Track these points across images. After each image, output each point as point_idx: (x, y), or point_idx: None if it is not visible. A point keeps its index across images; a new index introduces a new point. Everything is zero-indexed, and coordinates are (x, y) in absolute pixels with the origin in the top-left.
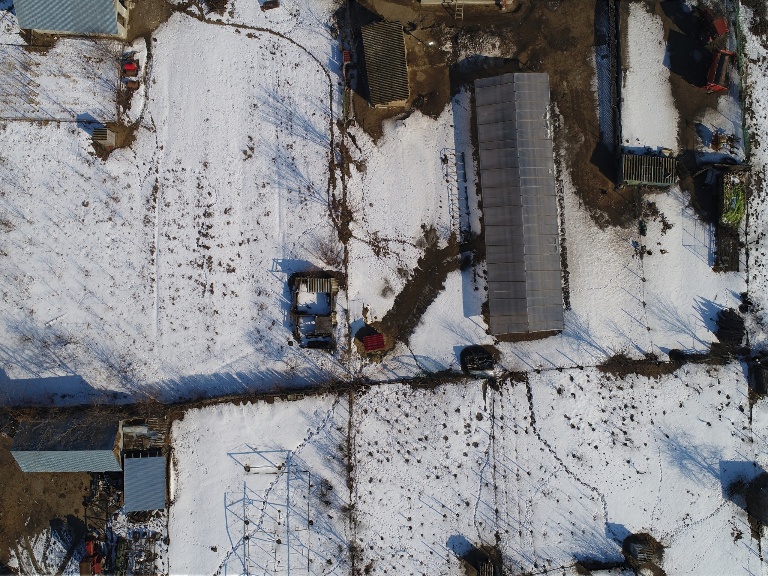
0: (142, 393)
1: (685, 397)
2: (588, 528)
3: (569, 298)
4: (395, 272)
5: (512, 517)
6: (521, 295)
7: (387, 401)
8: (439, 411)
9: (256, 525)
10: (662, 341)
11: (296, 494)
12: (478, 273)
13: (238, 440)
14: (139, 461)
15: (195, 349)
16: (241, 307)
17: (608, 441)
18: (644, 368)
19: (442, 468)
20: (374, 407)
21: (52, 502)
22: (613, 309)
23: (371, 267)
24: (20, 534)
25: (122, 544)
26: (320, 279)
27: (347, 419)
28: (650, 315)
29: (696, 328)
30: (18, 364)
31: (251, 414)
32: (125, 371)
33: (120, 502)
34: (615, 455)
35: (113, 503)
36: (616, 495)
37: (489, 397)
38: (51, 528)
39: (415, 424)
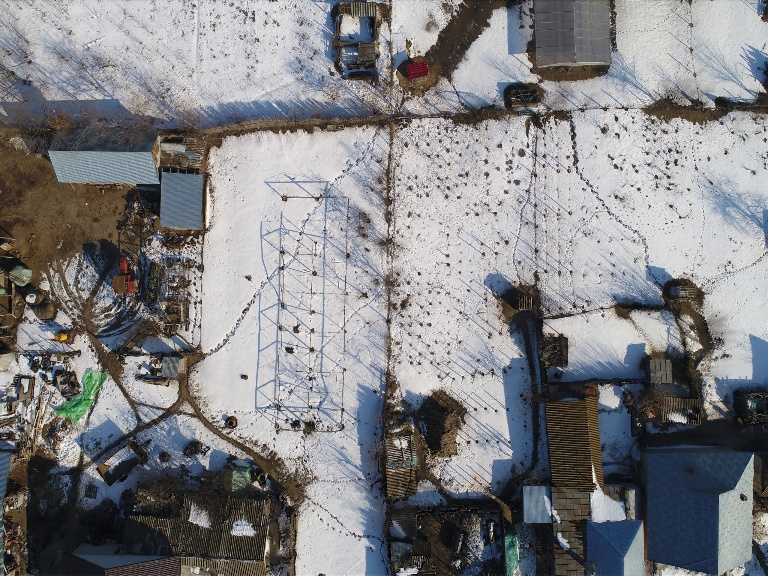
0: (180, 119)
1: (730, 144)
2: (628, 270)
3: (616, 39)
4: (440, 7)
5: (552, 256)
6: (569, 25)
7: (428, 135)
8: (481, 146)
9: (292, 256)
10: (708, 88)
11: (333, 226)
12: (524, 10)
13: (276, 169)
14: (177, 176)
15: (235, 76)
16: (282, 36)
17: (651, 184)
18: (689, 113)
19: (482, 205)
20: (415, 141)
21: (85, 226)
22: (660, 53)
23: (416, 1)
24: (52, 257)
25: (156, 266)
26: (365, 3)
27: (387, 151)
28: (697, 61)
29: (743, 77)
30: (55, 85)
31: (290, 143)
32: (163, 97)
33: (155, 228)
34: (658, 198)
35: (147, 228)
36: (658, 239)
37: (532, 134)
38: (84, 252)
39: (456, 160)
